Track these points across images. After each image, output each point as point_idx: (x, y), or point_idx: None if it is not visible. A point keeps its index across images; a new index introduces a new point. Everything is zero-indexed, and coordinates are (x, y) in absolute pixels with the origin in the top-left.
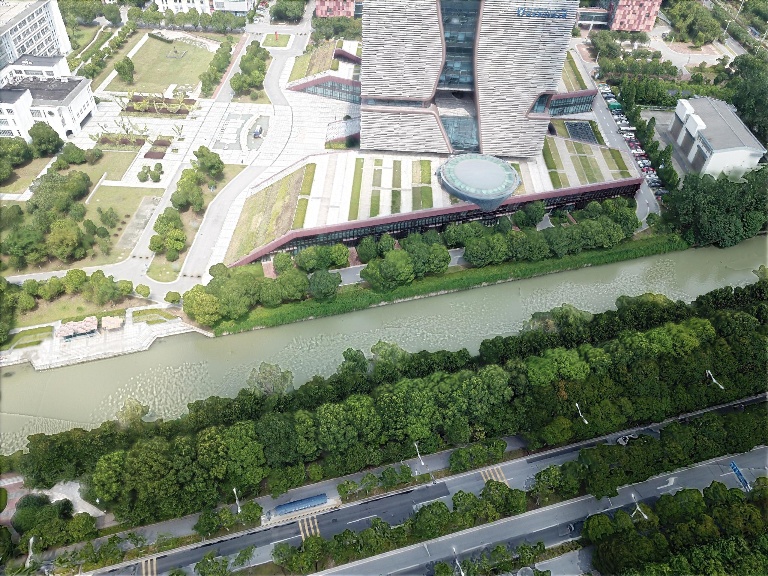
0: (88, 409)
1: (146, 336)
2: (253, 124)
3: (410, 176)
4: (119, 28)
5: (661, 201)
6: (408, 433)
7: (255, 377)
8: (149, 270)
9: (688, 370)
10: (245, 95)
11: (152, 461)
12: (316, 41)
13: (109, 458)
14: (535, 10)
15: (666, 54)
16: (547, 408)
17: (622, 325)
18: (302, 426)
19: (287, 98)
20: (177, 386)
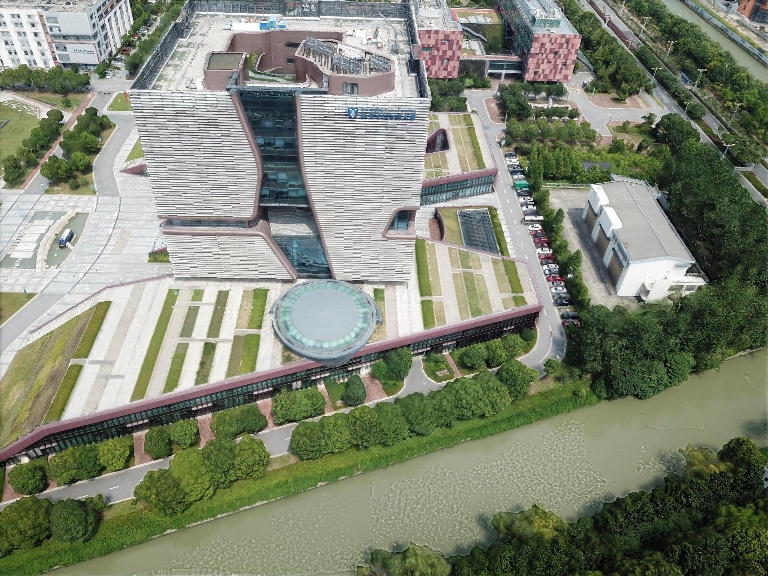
0: None
1: None
2: (64, 226)
3: (235, 317)
4: None
5: (567, 329)
6: None
7: None
8: None
9: None
10: (64, 183)
11: None
12: None
13: None
14: (372, 110)
15: (586, 109)
16: None
17: None
18: None
19: (118, 185)
20: None
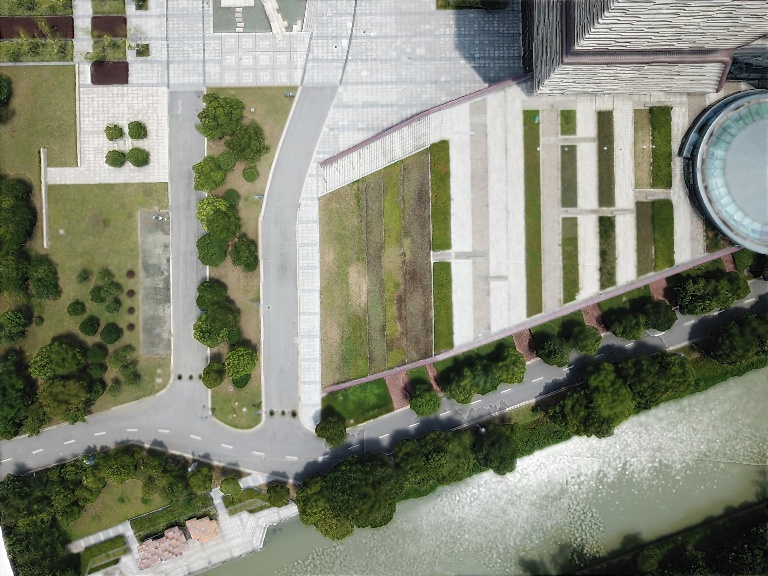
0: None
1: (253, 529)
2: None
3: (631, 166)
4: None
5: None
6: None
7: None
8: (214, 406)
9: None
10: None
11: None
12: None
13: None
14: None
15: None
16: None
17: None
18: None
19: None
20: None
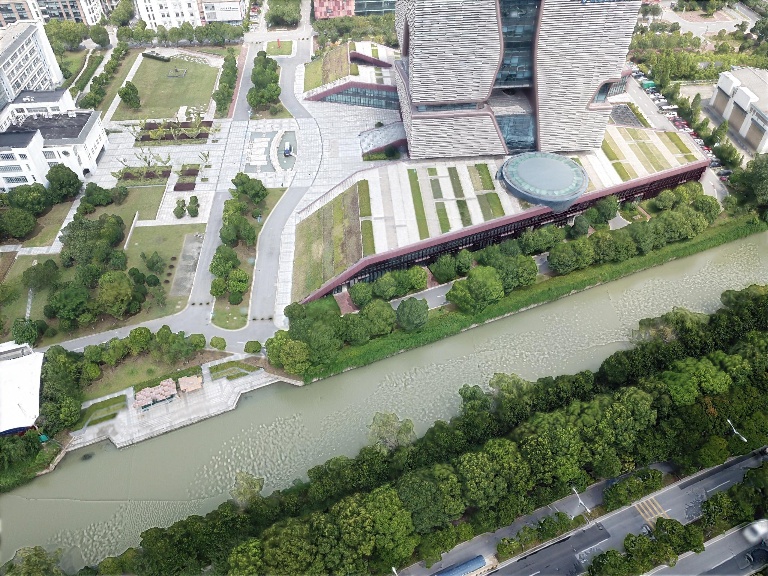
0: (183, 484)
1: (229, 393)
2: (280, 141)
3: (470, 183)
4: (108, 50)
5: (727, 181)
6: (558, 475)
7: (376, 432)
8: (214, 317)
9: None
10: (263, 111)
11: (297, 549)
12: (323, 45)
13: (242, 549)
14: None
15: (680, 25)
16: (698, 429)
17: (742, 324)
18: (446, 484)
19: (308, 109)
20: (275, 446)
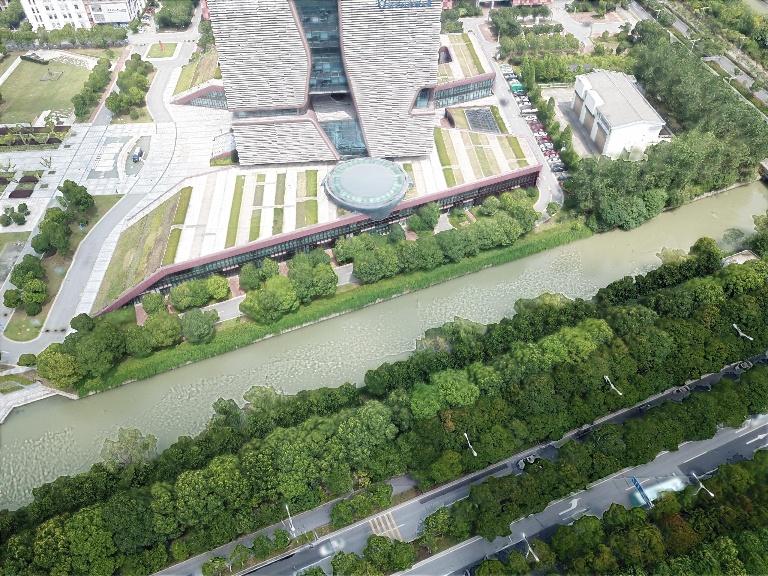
0: None
1: (1, 408)
2: (133, 147)
3: (294, 190)
4: None
5: (563, 186)
6: (281, 492)
7: (109, 449)
8: (7, 329)
9: (585, 378)
10: (125, 115)
11: None
12: (203, 47)
13: None
14: (396, 0)
15: (569, 26)
16: (433, 443)
17: (517, 334)
18: (158, 502)
19: (171, 113)
20: (38, 461)
